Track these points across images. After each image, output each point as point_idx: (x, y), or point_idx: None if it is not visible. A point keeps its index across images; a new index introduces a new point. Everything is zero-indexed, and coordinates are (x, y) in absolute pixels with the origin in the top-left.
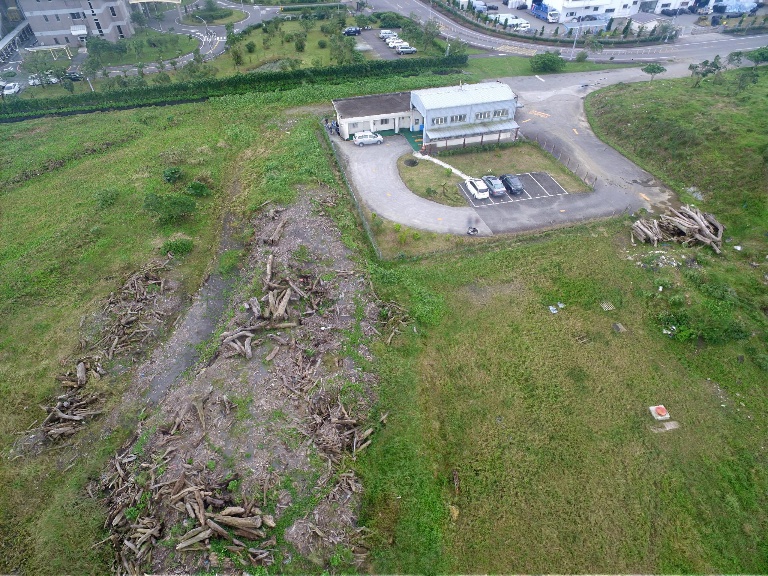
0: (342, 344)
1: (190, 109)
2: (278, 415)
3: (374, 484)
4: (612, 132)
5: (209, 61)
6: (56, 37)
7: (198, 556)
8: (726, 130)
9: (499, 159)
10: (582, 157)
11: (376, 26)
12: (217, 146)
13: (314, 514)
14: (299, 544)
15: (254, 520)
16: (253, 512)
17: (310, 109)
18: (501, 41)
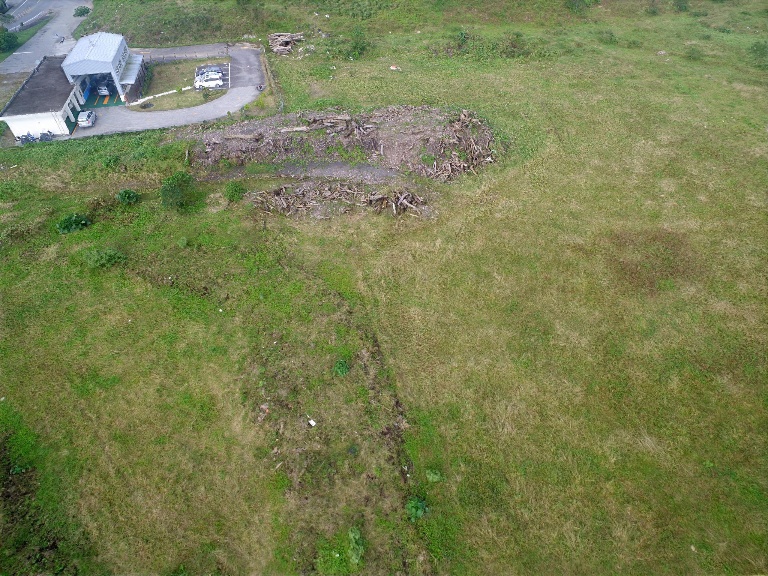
0: None
1: None
2: None
3: None
4: (162, 41)
5: None
6: None
7: None
8: (208, 8)
9: None
10: None
11: None
12: (8, 208)
13: None
14: None
15: None
16: None
17: None
18: None
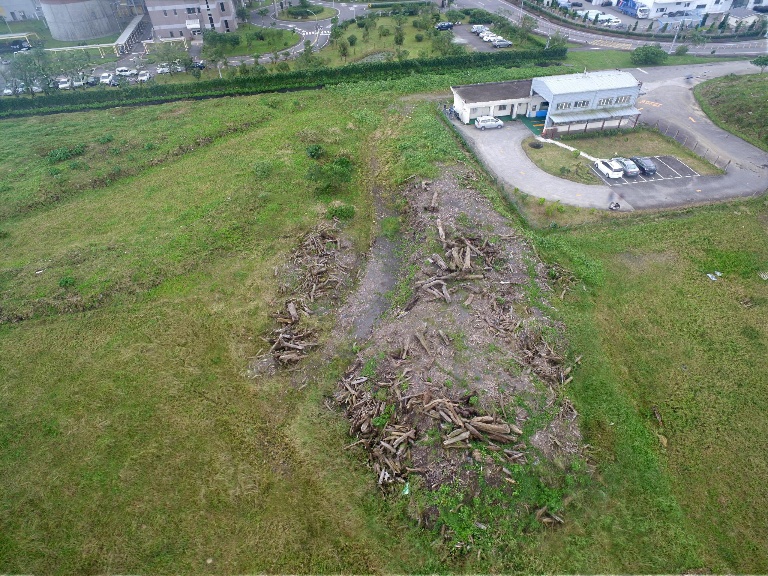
0: (525, 296)
1: (311, 95)
2: (493, 348)
3: (586, 412)
4: (732, 120)
5: (315, 53)
6: (172, 31)
7: (461, 453)
8: None
9: (622, 143)
10: (705, 143)
11: (465, 22)
12: (347, 128)
13: (551, 427)
14: (545, 450)
15: (505, 426)
16: (499, 421)
17: (423, 96)
18: (593, 36)
